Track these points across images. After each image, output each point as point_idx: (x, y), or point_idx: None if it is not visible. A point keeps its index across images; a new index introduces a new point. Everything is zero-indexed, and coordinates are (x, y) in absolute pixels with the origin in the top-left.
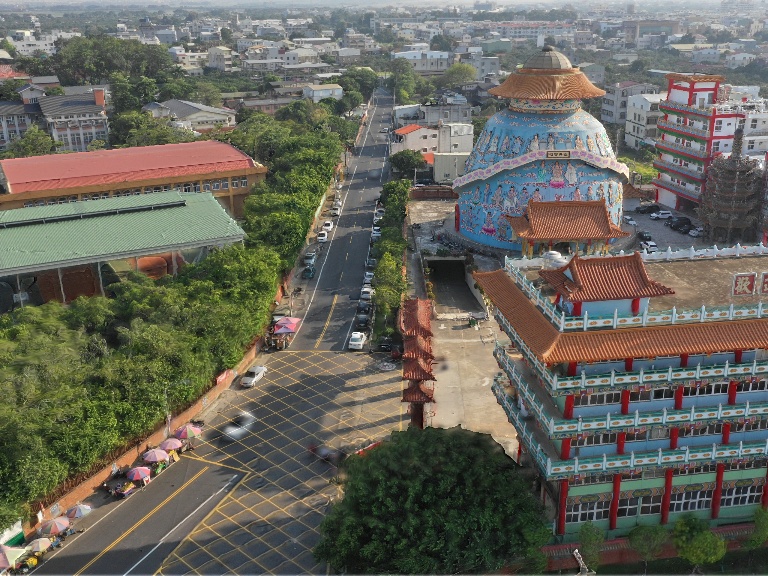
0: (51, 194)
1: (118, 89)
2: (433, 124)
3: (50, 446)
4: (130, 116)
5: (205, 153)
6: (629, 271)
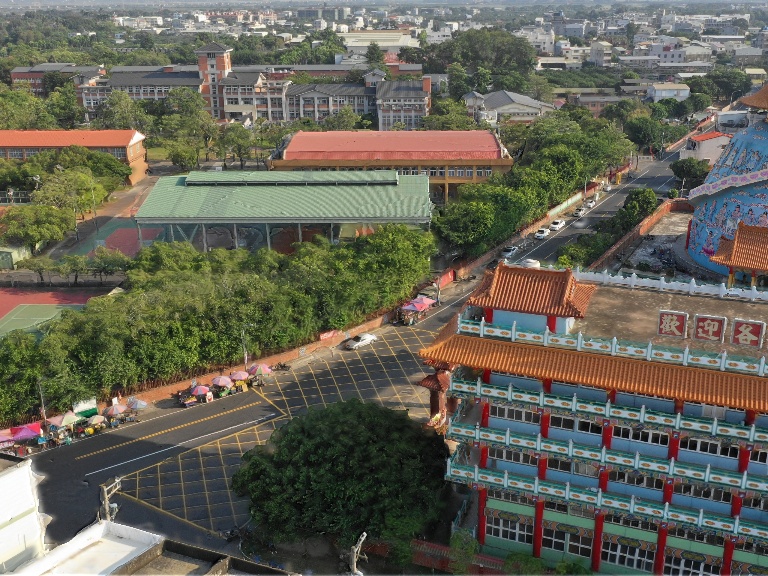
0: (314, 164)
1: (454, 78)
2: None
3: (130, 349)
4: (443, 103)
5: (464, 141)
6: (552, 287)
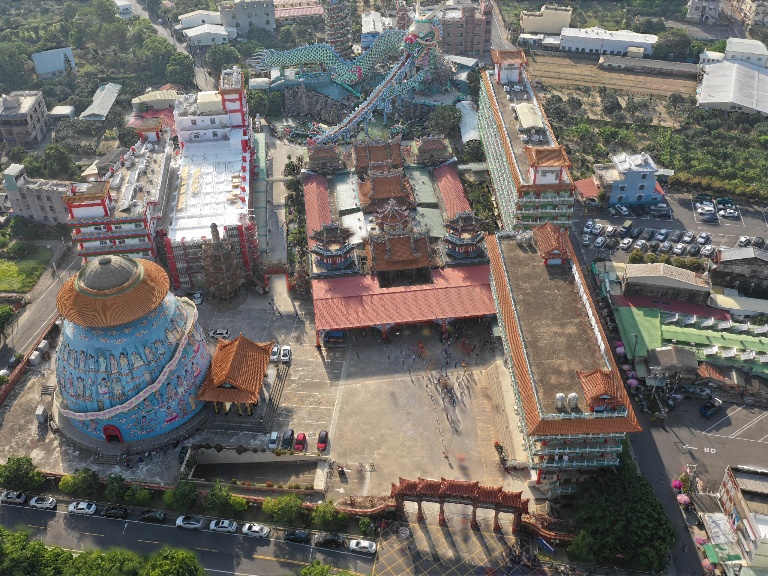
0: None
1: None
2: None
3: None
4: None
5: None
6: None
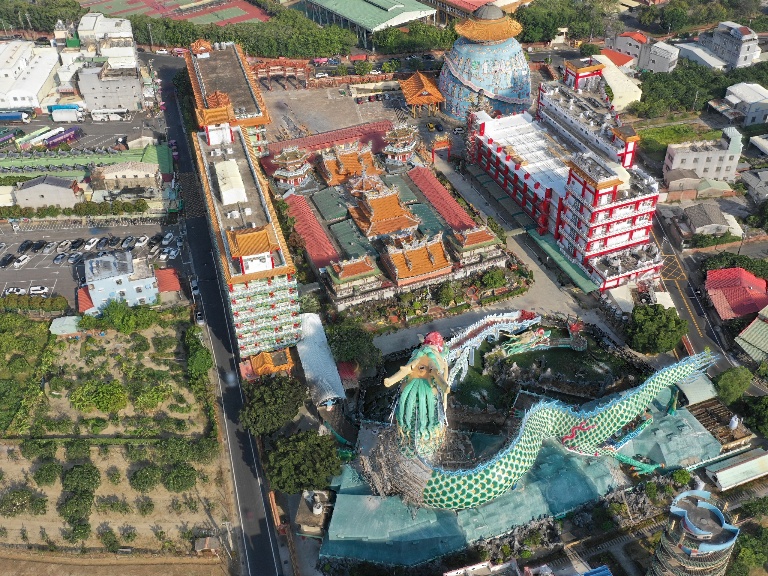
0: None
1: None
2: (716, 45)
3: None
4: None
5: None
6: None
